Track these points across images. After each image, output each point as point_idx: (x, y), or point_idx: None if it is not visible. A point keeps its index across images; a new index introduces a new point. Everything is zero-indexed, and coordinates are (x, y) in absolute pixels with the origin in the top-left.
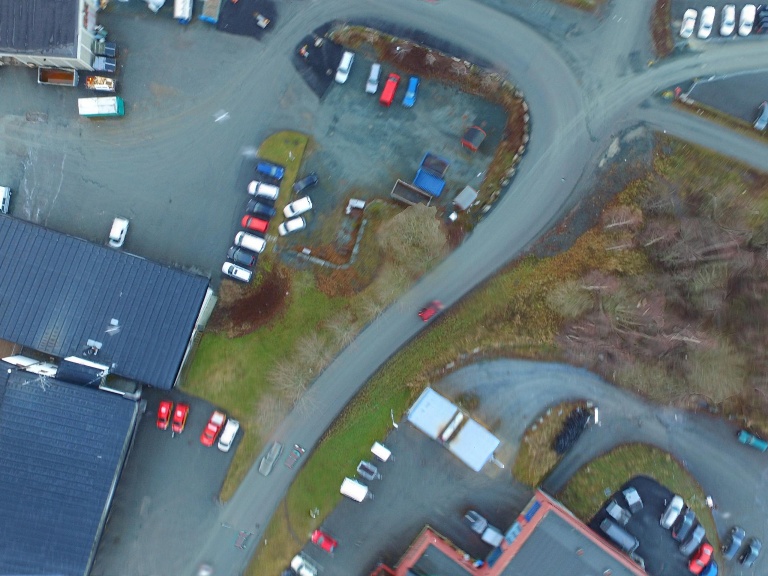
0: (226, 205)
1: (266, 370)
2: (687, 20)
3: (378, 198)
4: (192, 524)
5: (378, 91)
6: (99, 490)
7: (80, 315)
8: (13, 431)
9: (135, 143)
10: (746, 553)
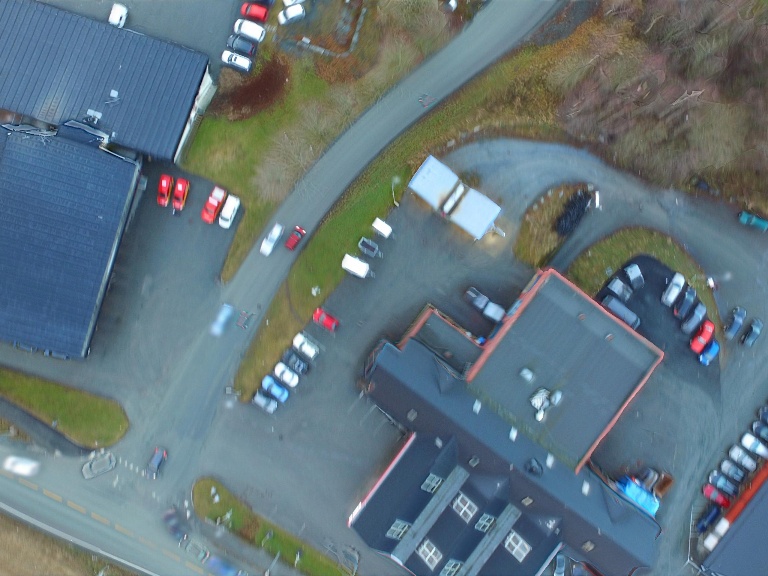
0: None
1: (266, 150)
2: None
3: None
4: (194, 303)
5: None
6: (100, 251)
7: (80, 86)
8: (13, 185)
9: None
10: (747, 332)
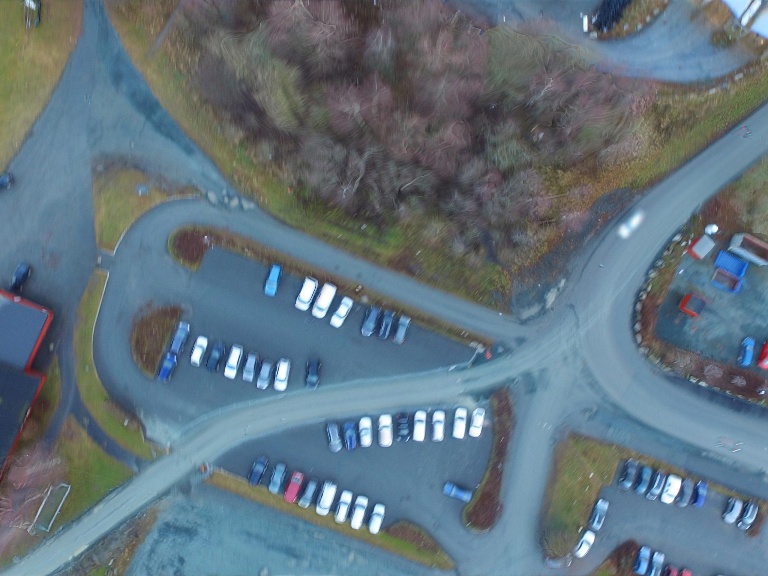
0: None
1: None
2: None
3: None
4: None
5: None
6: None
7: None
8: None
9: None
10: None
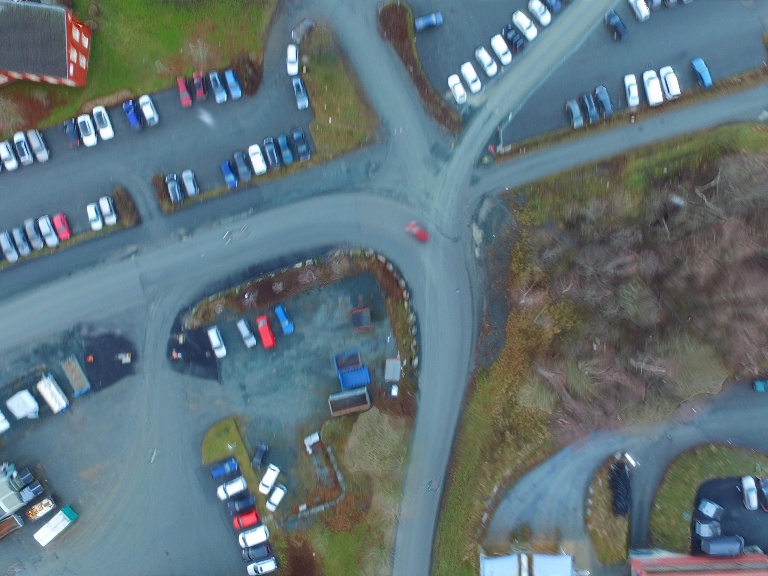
0: (212, 521)
1: None
2: (454, 89)
3: (325, 422)
4: None
5: (258, 341)
6: None
7: None
8: None
9: (104, 530)
10: None
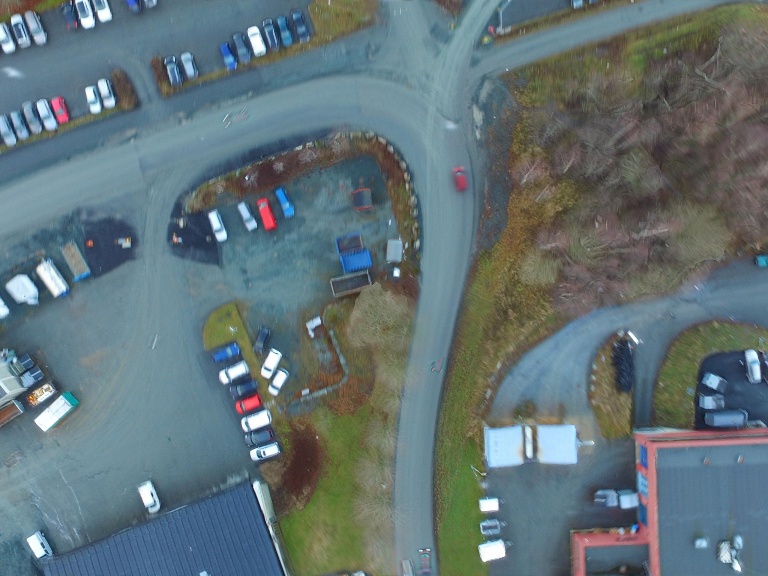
0: (214, 407)
1: (350, 513)
2: None
3: (327, 305)
4: None
5: (259, 224)
6: None
7: None
8: None
9: (105, 417)
10: None
